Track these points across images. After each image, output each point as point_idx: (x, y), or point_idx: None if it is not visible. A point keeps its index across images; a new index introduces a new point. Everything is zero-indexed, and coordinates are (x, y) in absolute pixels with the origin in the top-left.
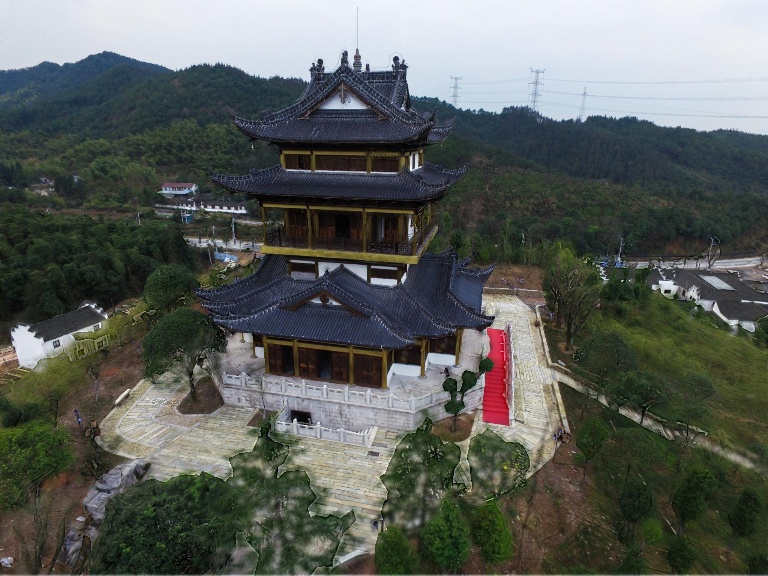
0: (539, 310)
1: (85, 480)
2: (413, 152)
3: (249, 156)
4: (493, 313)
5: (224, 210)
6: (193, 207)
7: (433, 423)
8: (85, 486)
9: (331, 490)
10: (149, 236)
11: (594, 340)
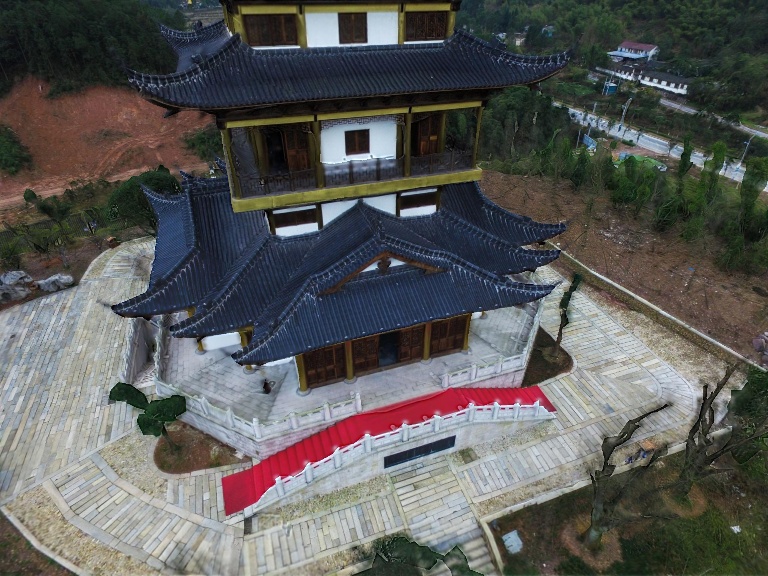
0: (723, 436)
1: (53, 271)
2: (337, 7)
3: (759, 11)
4: (610, 375)
5: (661, 86)
6: (630, 76)
7: (187, 425)
8: (45, 275)
9: (46, 395)
10: (515, 101)
11: (399, 557)
